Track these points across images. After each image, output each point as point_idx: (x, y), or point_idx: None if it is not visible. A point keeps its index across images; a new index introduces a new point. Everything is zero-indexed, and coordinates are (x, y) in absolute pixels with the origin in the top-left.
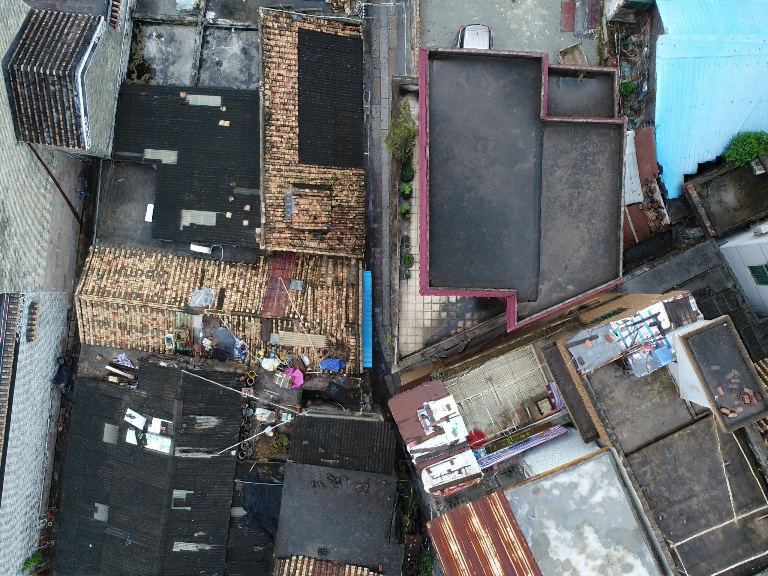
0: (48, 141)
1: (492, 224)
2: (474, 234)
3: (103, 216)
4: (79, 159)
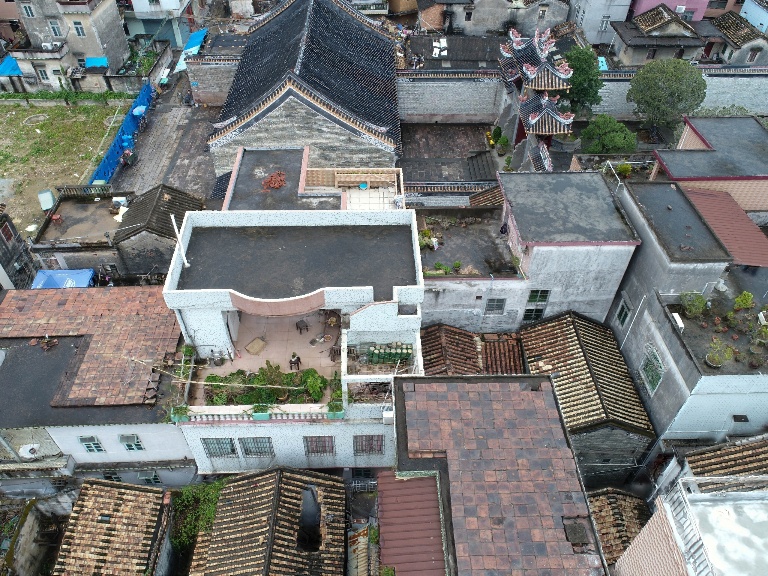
0: None
1: None
2: None
3: None
4: None
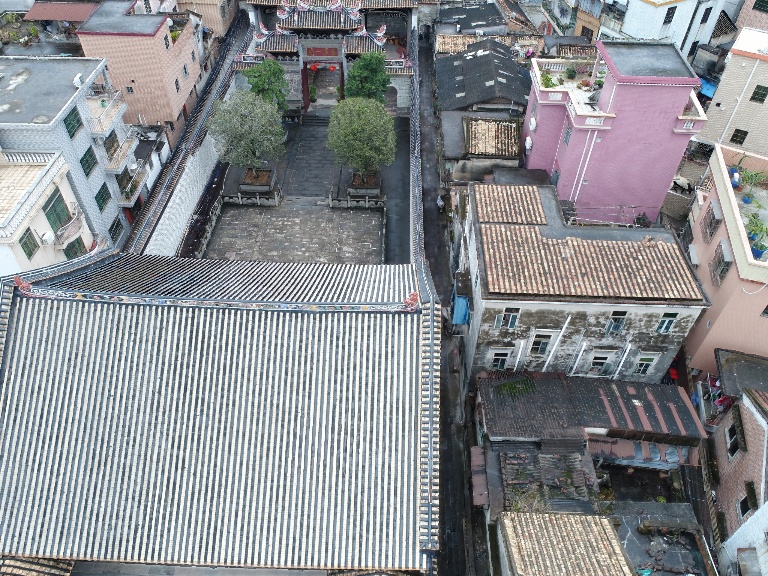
0: (428, 1)
1: None
2: None
3: None
4: None
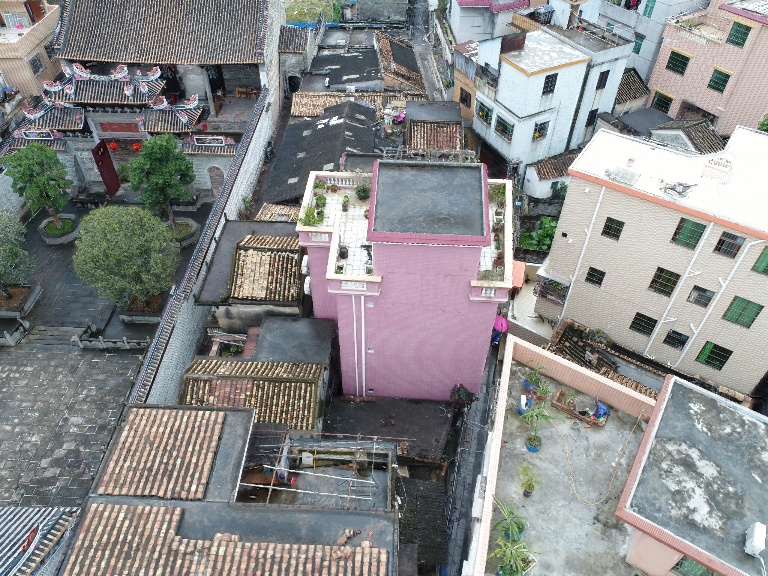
0: (291, 49)
1: None
2: None
3: (303, 86)
4: (284, 93)
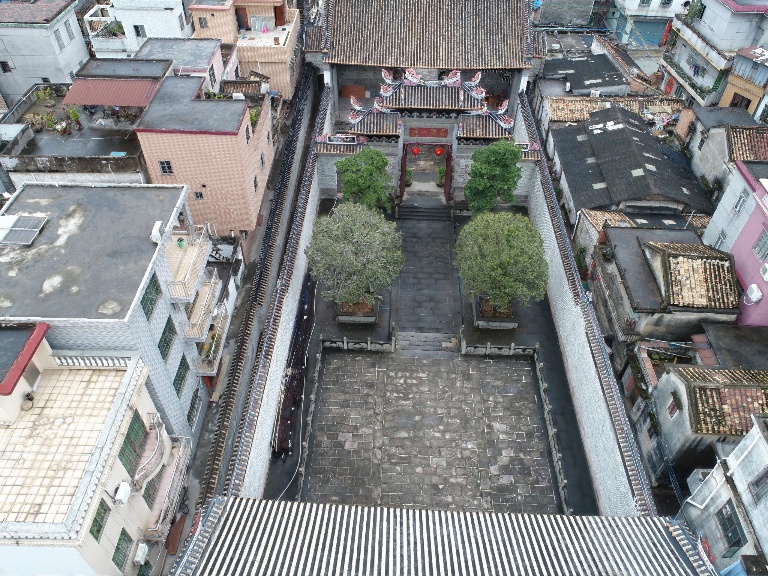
0: None
1: (747, 2)
2: (743, 3)
3: None
4: None
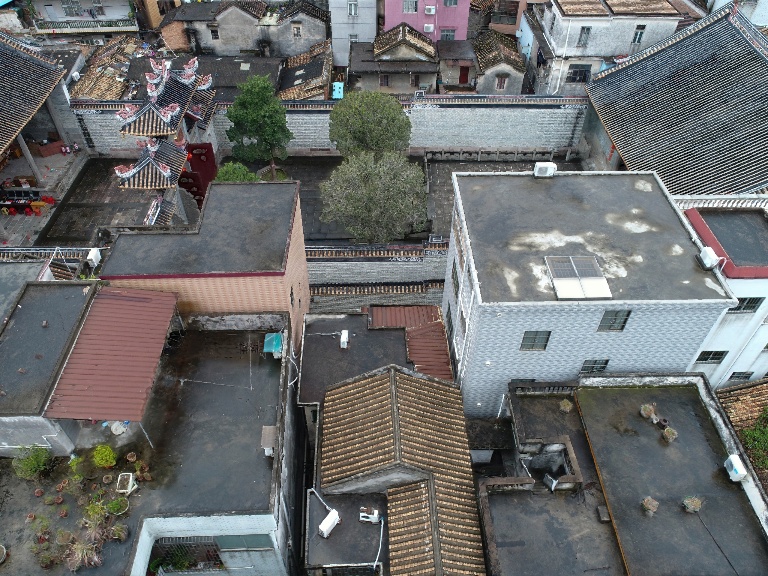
0: None
1: None
2: None
3: None
4: None
